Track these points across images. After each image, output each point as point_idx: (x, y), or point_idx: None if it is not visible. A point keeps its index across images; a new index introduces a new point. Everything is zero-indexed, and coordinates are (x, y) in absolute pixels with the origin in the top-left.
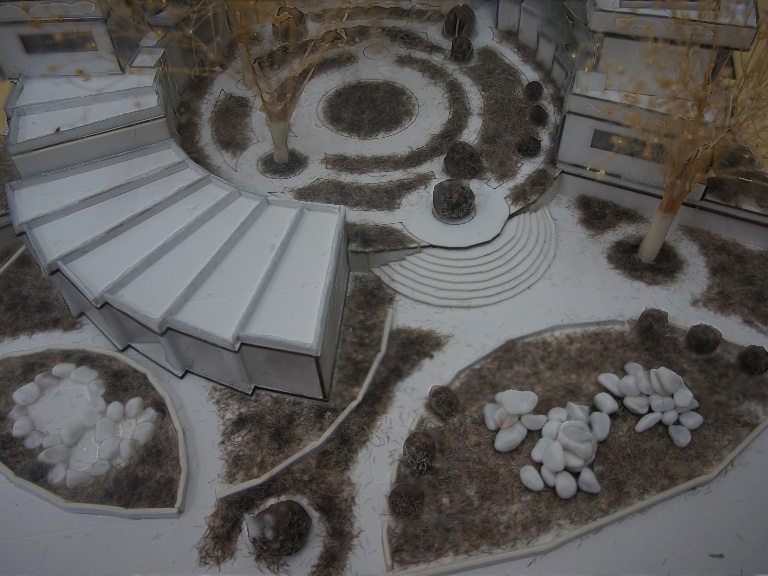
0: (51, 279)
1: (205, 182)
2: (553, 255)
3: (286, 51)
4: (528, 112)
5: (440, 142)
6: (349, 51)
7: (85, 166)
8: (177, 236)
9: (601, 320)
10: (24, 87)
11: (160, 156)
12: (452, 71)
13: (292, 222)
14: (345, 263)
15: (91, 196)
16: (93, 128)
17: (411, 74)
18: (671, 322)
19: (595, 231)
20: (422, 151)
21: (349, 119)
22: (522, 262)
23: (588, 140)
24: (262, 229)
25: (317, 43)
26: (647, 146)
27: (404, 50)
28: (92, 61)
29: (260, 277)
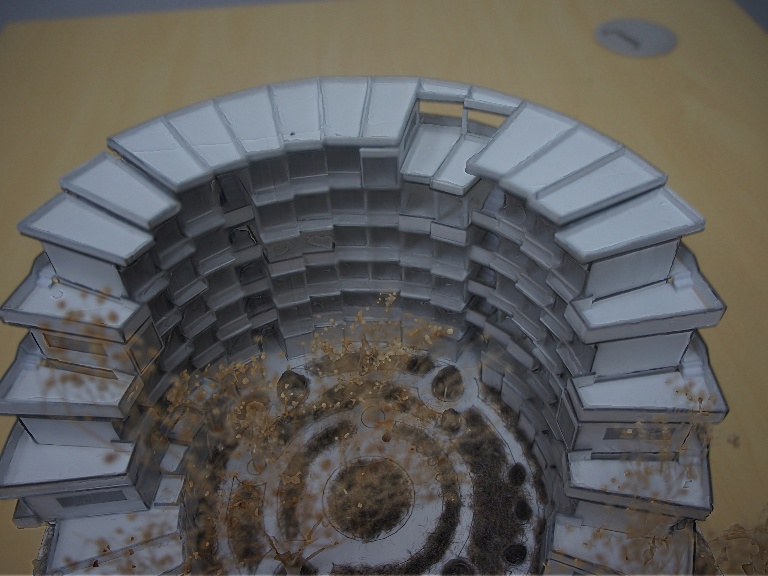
0: None
1: None
2: None
3: (291, 422)
4: (513, 502)
5: (436, 548)
6: (348, 418)
7: None
8: None
9: None
10: (60, 533)
11: None
12: (443, 444)
13: None
14: None
15: None
16: None
17: (406, 449)
18: None
19: None
20: (420, 558)
21: (352, 515)
22: None
23: (569, 575)
24: None
25: (319, 410)
26: None
27: (398, 414)
28: (121, 505)
29: None
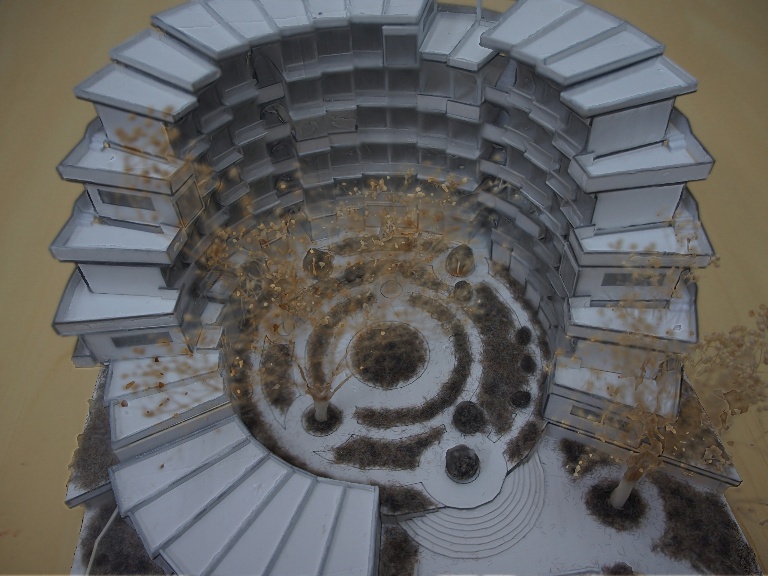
0: (154, 561)
1: (266, 460)
2: (542, 503)
3: (316, 292)
4: (519, 359)
5: (449, 394)
6: (369, 290)
7: (169, 446)
8: (249, 521)
9: (581, 571)
10: (113, 371)
11: (226, 430)
12: (456, 311)
13: (338, 505)
14: (378, 520)
15: (177, 480)
16: (176, 420)
17: (422, 315)
18: (635, 570)
19: (576, 476)
20: (434, 403)
21: (373, 368)
22: (518, 515)
23: (568, 410)
24: (314, 508)
25: (342, 283)
26: (614, 420)
27: (415, 287)
28: (167, 348)
29: (317, 560)
